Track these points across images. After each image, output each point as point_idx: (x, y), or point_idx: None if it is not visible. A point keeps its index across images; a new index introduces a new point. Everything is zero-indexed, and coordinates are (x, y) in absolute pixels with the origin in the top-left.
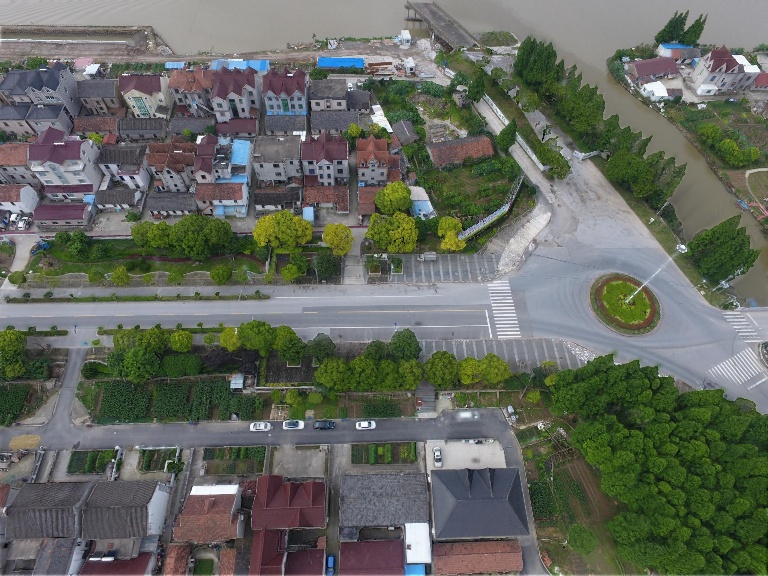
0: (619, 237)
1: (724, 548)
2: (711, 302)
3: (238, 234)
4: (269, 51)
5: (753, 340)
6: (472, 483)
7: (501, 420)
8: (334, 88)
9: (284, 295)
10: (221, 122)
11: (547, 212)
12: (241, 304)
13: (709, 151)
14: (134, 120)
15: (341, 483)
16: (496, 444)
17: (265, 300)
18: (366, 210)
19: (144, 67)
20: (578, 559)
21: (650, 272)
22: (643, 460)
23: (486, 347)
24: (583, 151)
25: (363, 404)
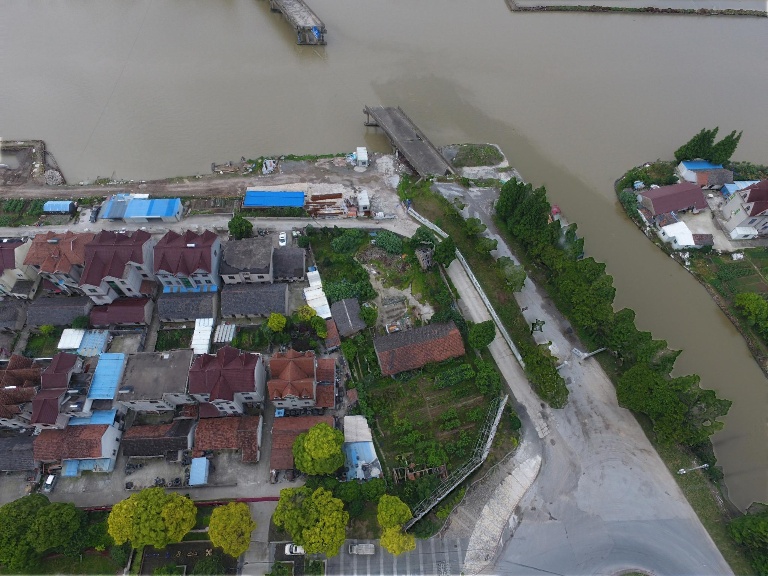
0: (636, 499)
1: None
2: None
3: (93, 510)
4: (186, 178)
5: None
6: None
7: None
8: (255, 253)
9: None
10: (100, 304)
11: (536, 455)
12: None
13: (751, 330)
14: None
15: None
16: None
17: None
18: (281, 463)
19: (19, 207)
20: None
21: (682, 567)
22: None
23: None
24: (586, 343)
25: None
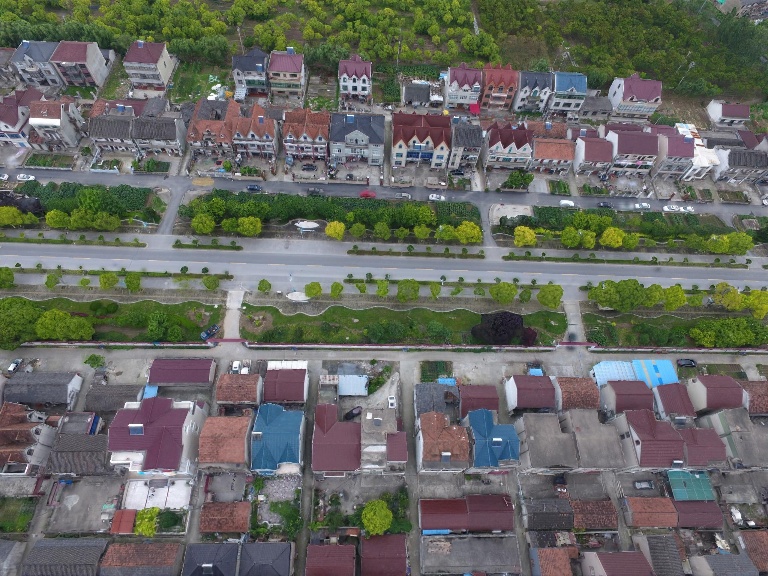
0: None
1: None
2: None
3: None
4: None
5: None
6: None
7: None
8: None
9: None
10: None
11: None
12: (5, 264)
13: None
14: (70, 563)
15: None
16: None
17: None
18: None
19: None
20: None
21: None
22: None
23: None
24: None
25: None
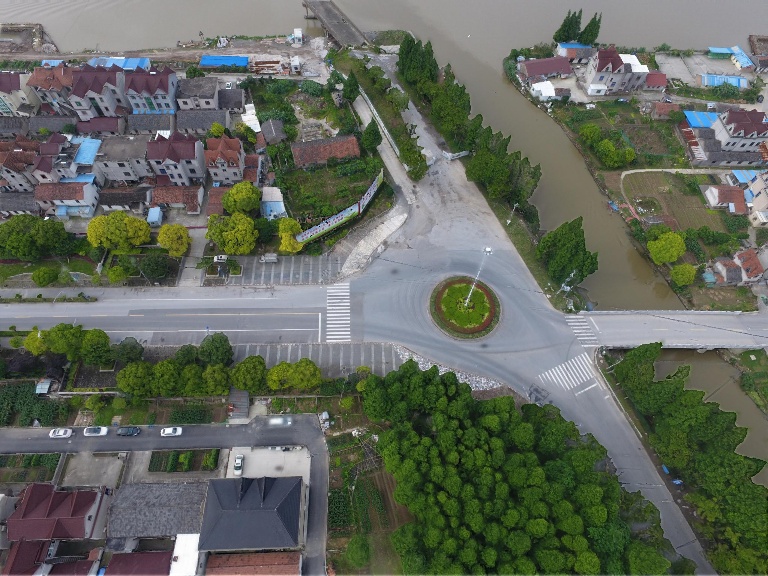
0: (473, 239)
1: (487, 561)
2: (555, 305)
3: (77, 235)
4: (156, 49)
5: (591, 344)
6: (246, 493)
7: (315, 426)
8: (203, 86)
9: (113, 297)
10: (85, 121)
11: (404, 213)
12: (66, 307)
13: (589, 152)
14: None
15: (117, 492)
16: (304, 451)
17: (92, 302)
18: (214, 211)
19: (22, 65)
20: (365, 571)
21: (498, 275)
22: (426, 469)
23: (312, 351)
24: (454, 151)
25: (172, 410)
